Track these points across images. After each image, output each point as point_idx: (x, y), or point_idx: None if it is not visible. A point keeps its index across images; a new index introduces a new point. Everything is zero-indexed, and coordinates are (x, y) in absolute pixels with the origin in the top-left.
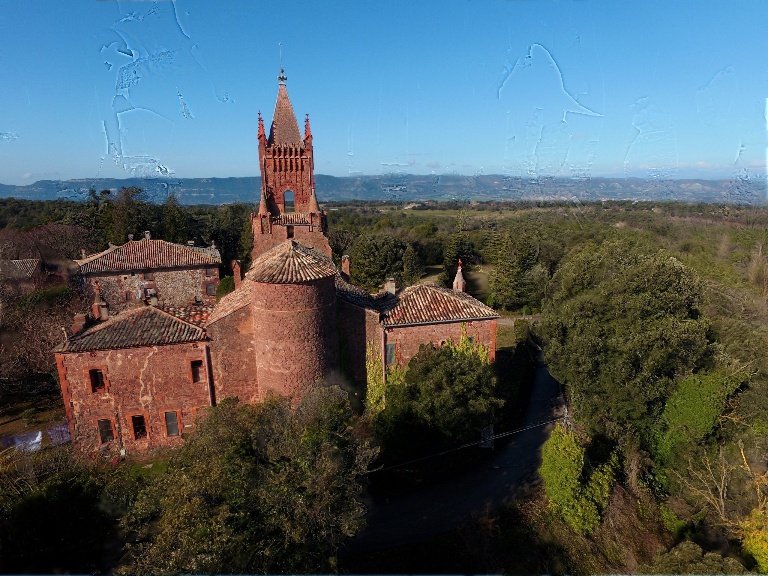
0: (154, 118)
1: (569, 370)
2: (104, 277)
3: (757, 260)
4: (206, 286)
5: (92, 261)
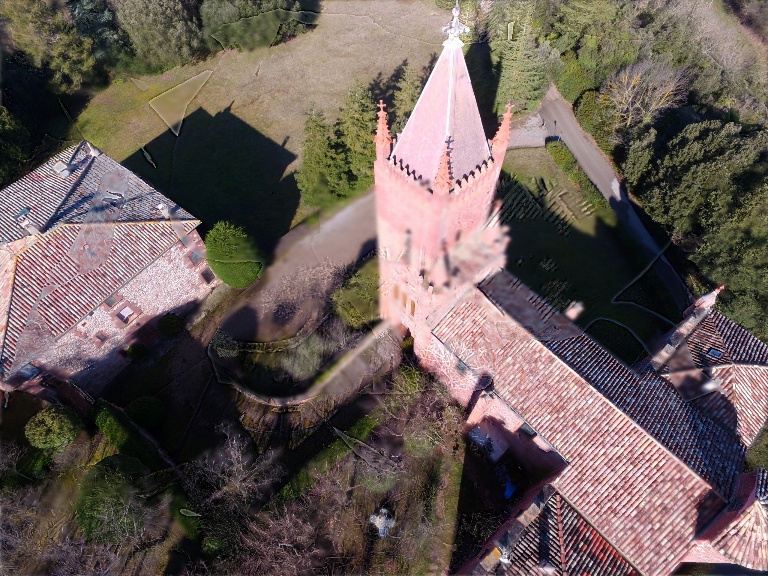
0: None
1: (767, 329)
2: None
3: None
4: (189, 258)
5: (5, 334)
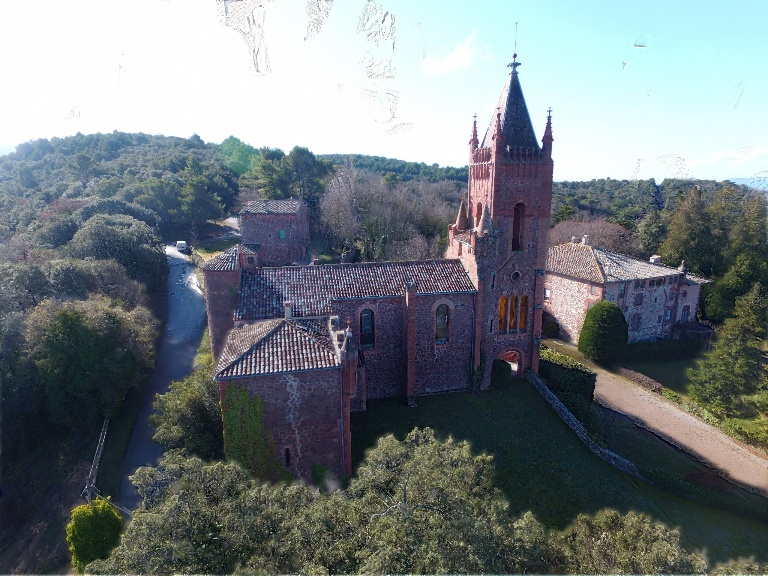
0: (696, 107)
1: None
2: None
3: None
4: (588, 304)
5: None
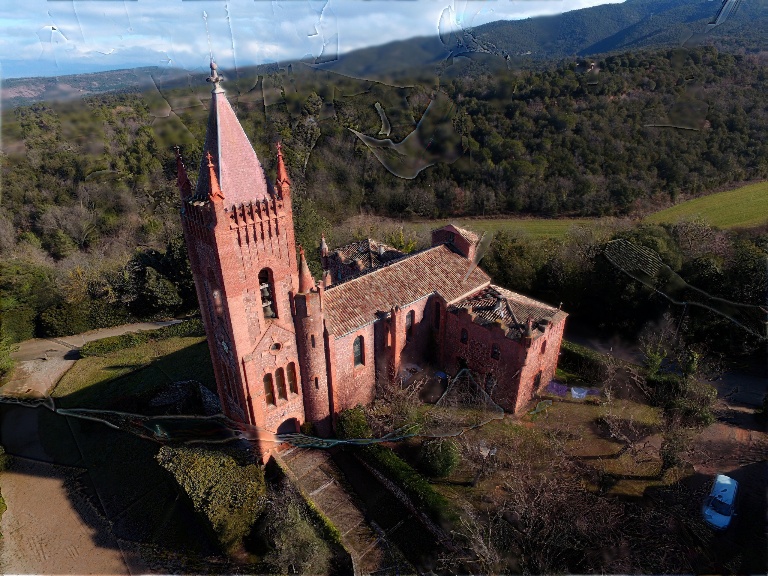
0: None
1: None
2: None
3: (80, 212)
4: None
5: None
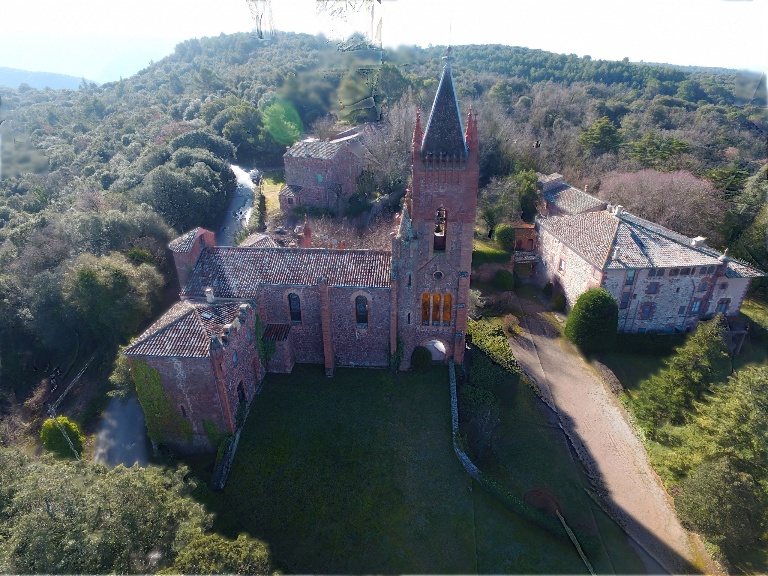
0: None
1: None
2: (549, 233)
3: None
4: (590, 286)
5: None
